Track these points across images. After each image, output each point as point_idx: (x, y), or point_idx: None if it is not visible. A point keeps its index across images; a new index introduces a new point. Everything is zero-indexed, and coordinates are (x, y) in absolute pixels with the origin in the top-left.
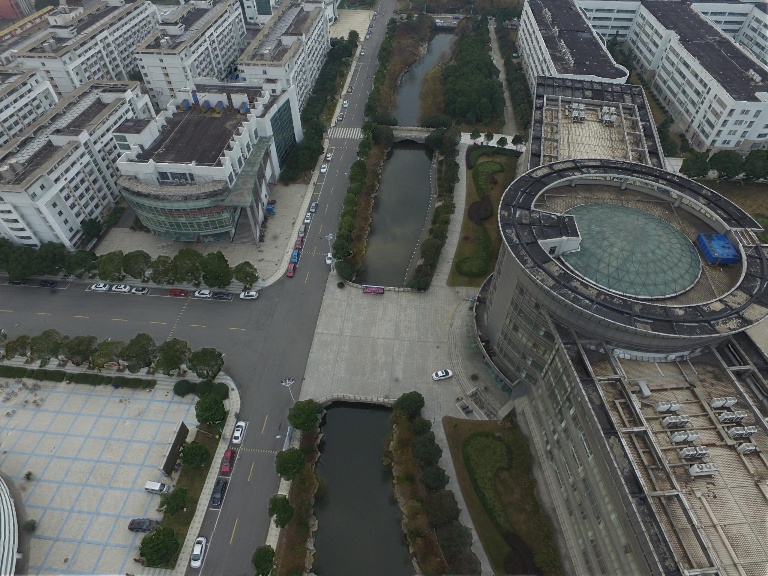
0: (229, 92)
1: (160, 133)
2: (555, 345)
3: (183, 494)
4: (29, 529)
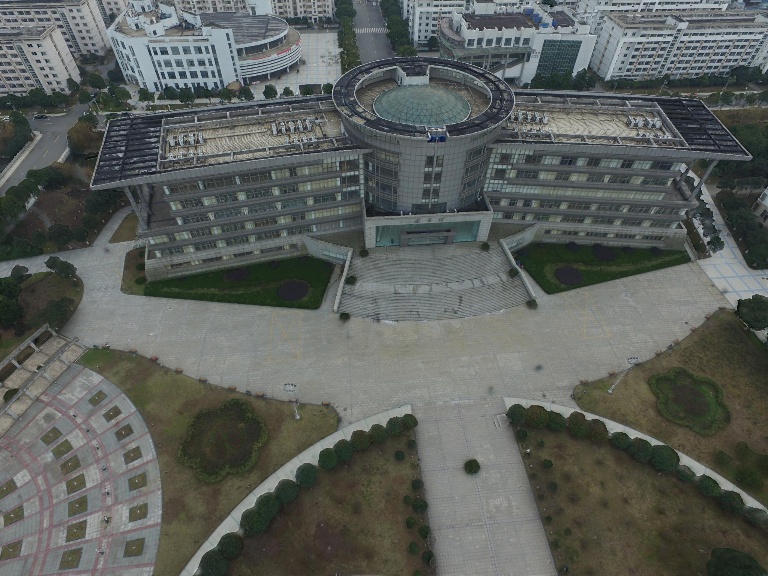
0: (565, 21)
1: (495, 14)
2: None
3: (289, 91)
4: (278, 77)
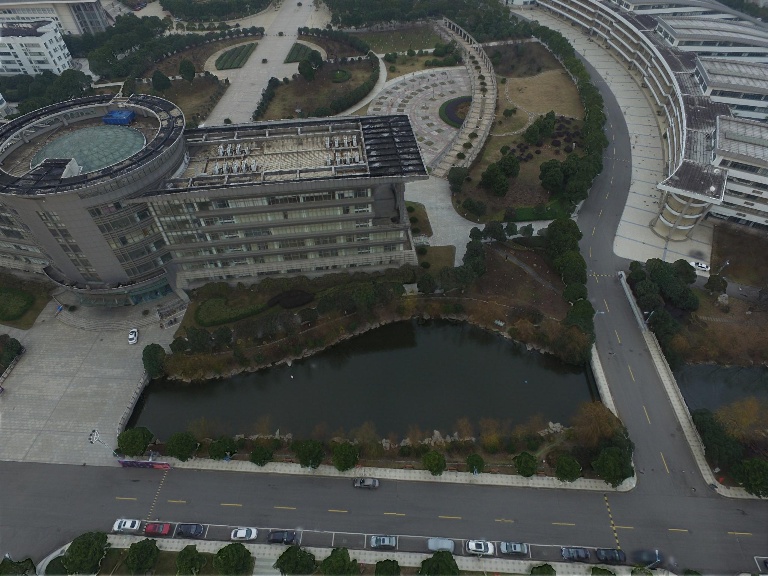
0: None
1: None
2: (152, 215)
3: (185, 548)
4: None
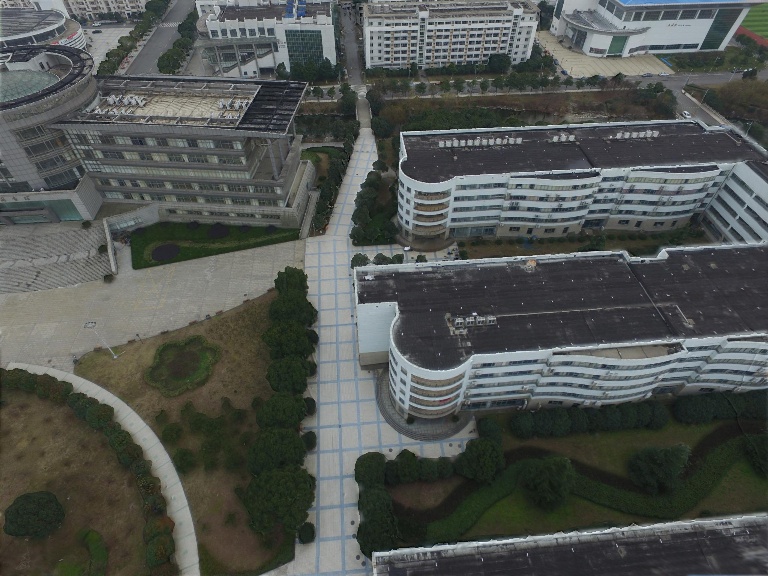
0: None
1: (259, 6)
2: None
3: None
4: None
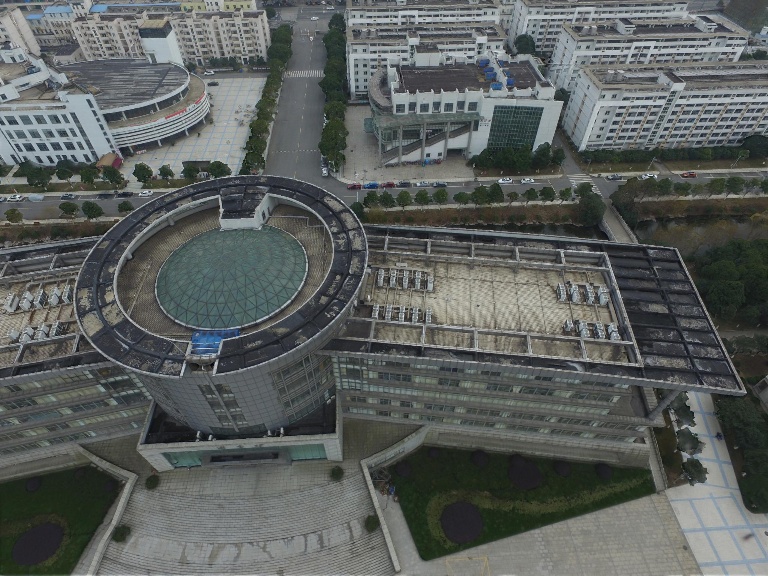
0: (527, 77)
1: (441, 66)
2: None
3: (165, 171)
4: (171, 143)
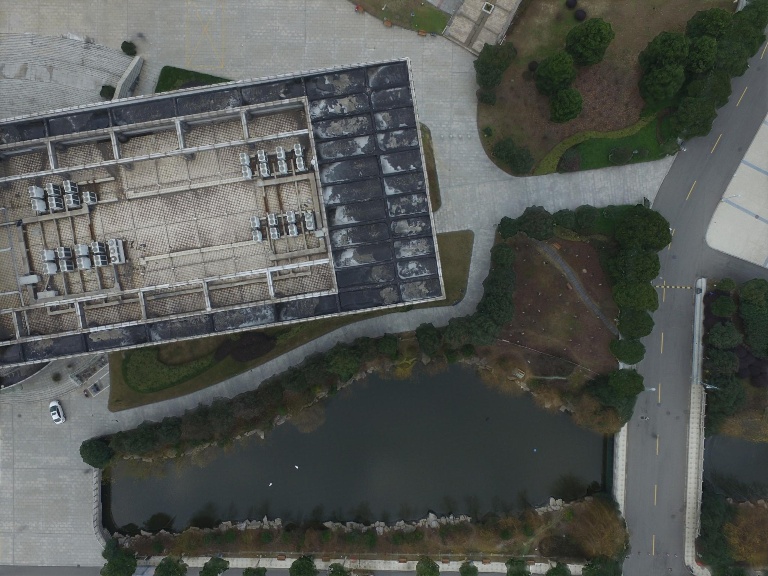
0: None
1: None
2: None
3: None
4: None
